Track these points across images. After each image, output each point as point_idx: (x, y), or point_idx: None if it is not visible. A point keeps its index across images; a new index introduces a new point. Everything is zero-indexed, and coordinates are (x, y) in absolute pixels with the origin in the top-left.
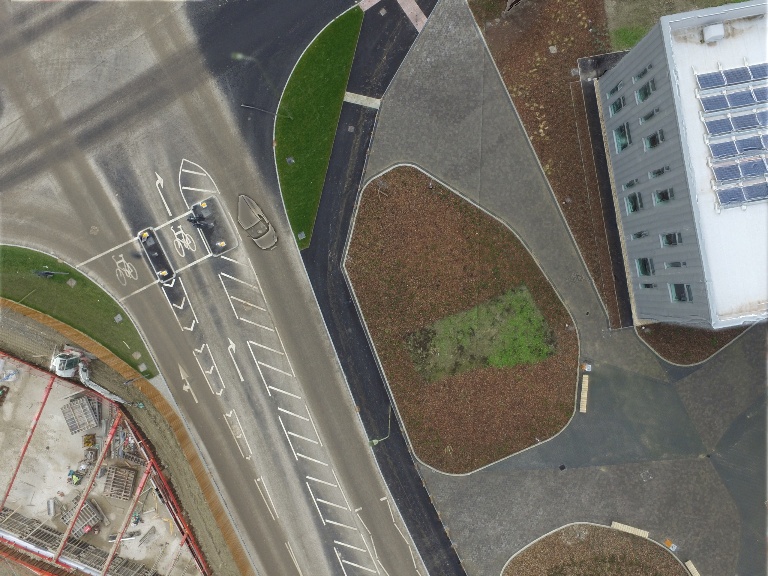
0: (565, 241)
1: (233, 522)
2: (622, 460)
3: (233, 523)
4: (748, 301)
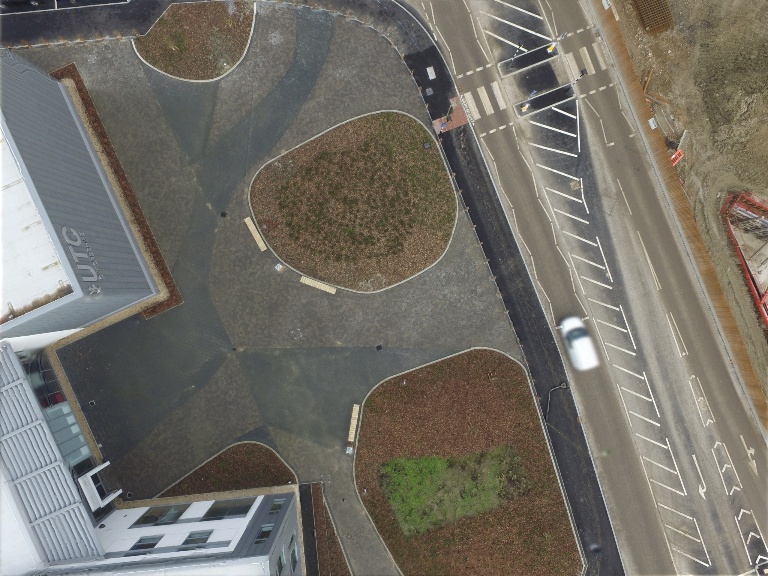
0: (361, 575)
1: (713, 313)
2: (319, 351)
3: (713, 312)
4: (225, 567)
